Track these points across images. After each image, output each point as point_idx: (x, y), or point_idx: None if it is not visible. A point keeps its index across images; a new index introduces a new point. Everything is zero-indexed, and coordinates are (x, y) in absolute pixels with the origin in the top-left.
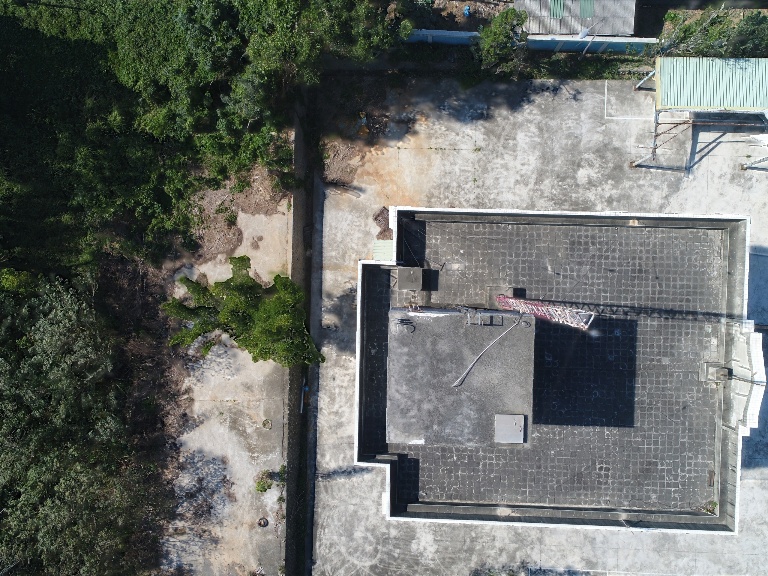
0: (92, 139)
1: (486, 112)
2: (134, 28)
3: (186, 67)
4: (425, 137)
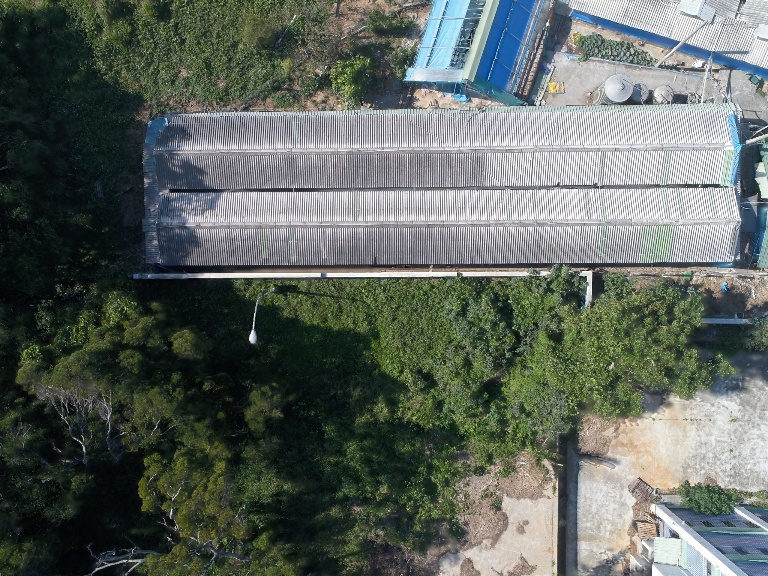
0: (359, 432)
1: (741, 383)
2: (397, 316)
3: (463, 368)
4: (680, 408)
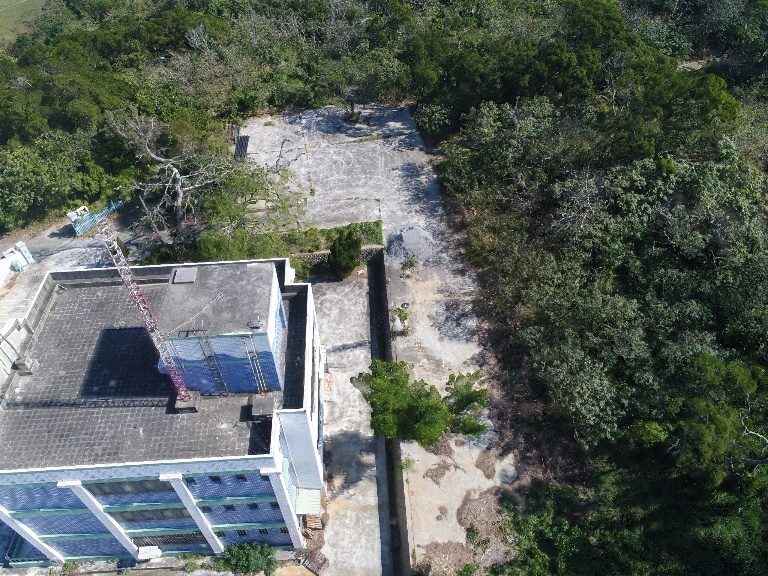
0: None
1: None
2: None
3: None
4: None
